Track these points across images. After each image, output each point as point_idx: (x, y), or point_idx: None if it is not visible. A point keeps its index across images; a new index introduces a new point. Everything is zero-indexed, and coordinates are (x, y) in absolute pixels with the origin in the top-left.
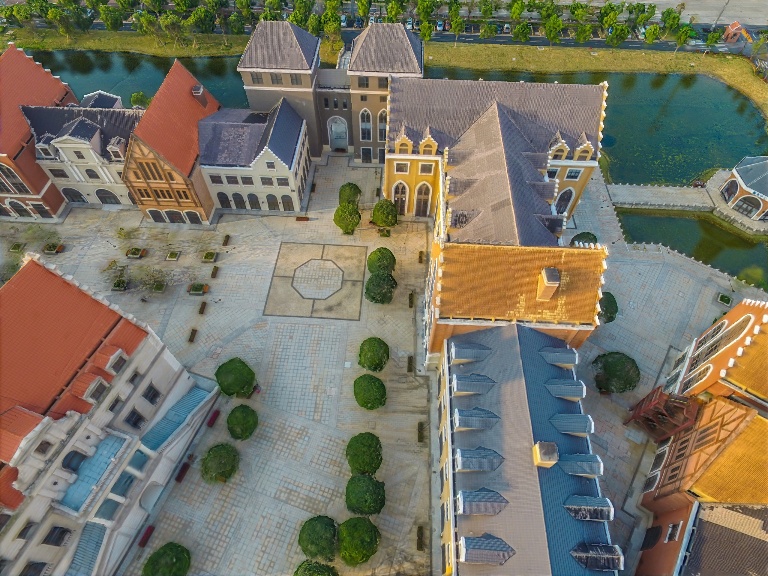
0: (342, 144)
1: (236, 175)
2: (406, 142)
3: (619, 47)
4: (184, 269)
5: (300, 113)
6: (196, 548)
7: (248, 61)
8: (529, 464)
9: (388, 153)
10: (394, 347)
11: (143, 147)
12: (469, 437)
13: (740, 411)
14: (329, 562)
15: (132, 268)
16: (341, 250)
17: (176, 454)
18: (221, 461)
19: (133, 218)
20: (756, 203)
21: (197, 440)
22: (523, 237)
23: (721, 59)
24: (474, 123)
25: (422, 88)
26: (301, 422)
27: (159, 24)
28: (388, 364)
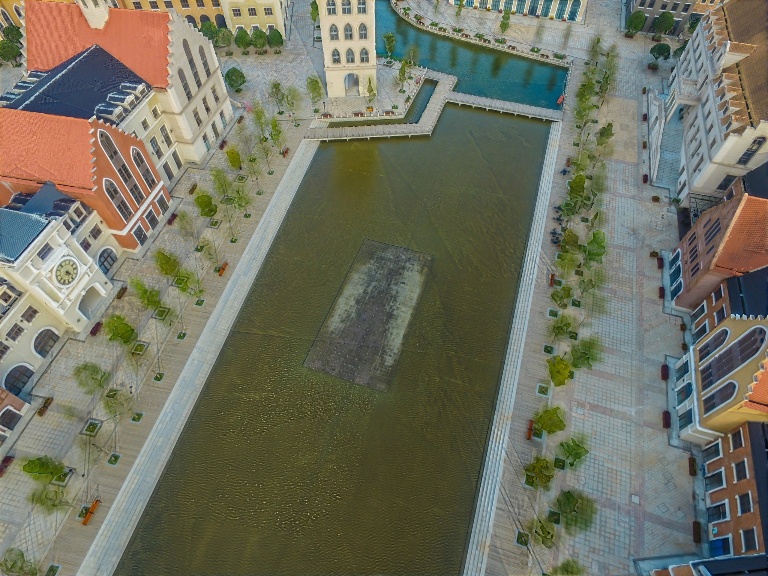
0: None
1: None
2: None
3: None
4: None
5: None
6: None
7: None
8: None
9: None
10: None
11: None
12: None
13: None
14: None
15: None
16: None
17: None
18: None
19: None
20: None
21: None
22: None
23: None
24: None
25: None
26: None
27: None
28: None
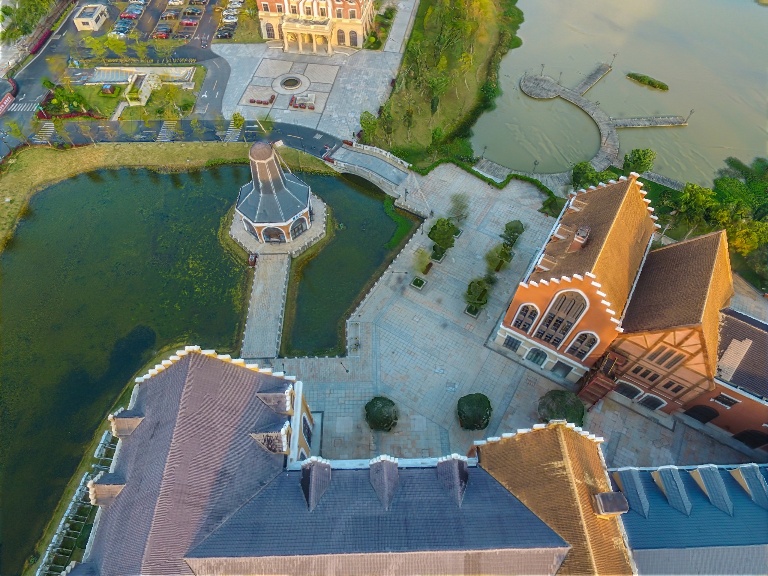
0: None
1: None
2: None
3: None
4: None
5: None
6: None
7: None
8: None
9: None
10: None
11: None
12: None
13: (683, 332)
14: None
15: None
16: None
17: None
18: None
19: None
20: (300, 221)
21: None
22: (542, 537)
23: (13, 170)
24: None
25: None
26: None
27: None
28: None
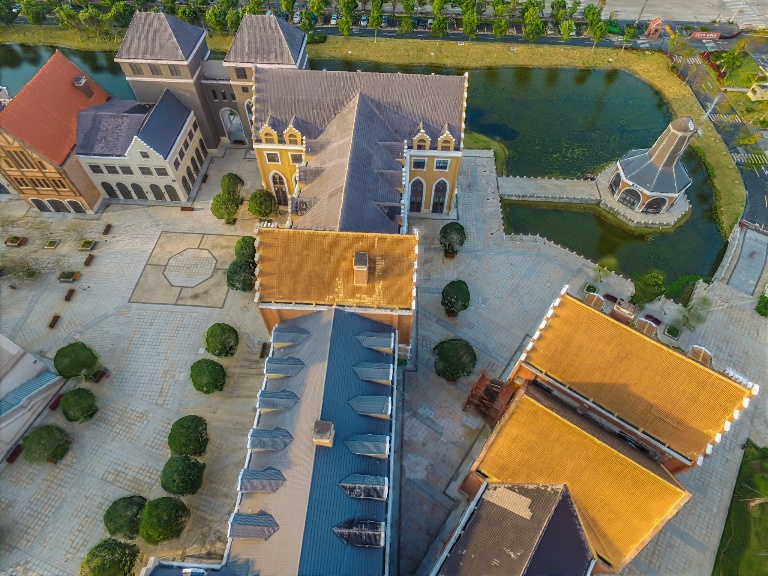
0: (243, 136)
1: (114, 165)
2: (270, 132)
3: (540, 43)
4: (60, 257)
5: (186, 104)
6: (14, 527)
7: (125, 52)
8: (310, 443)
9: (255, 143)
10: (252, 334)
11: (6, 135)
12: (271, 418)
13: None
14: (129, 540)
15: (9, 256)
16: (219, 239)
17: (9, 436)
18: (41, 441)
19: (20, 207)
20: (636, 195)
21: (37, 423)
22: (347, 223)
23: (639, 55)
24: (338, 113)
25: (286, 78)
26: (143, 406)
27: (79, 18)
28: (241, 350)
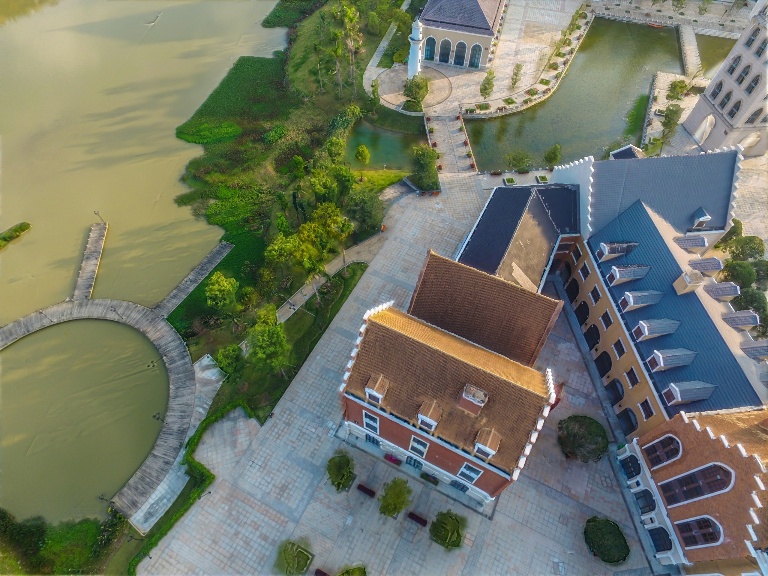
0: None
1: None
2: None
3: None
4: None
5: None
6: None
7: None
8: None
9: None
10: None
11: None
12: (729, 312)
13: None
14: None
15: None
16: None
17: None
18: None
19: None
20: None
21: None
22: None
23: None
24: None
25: None
26: None
27: None
28: None
